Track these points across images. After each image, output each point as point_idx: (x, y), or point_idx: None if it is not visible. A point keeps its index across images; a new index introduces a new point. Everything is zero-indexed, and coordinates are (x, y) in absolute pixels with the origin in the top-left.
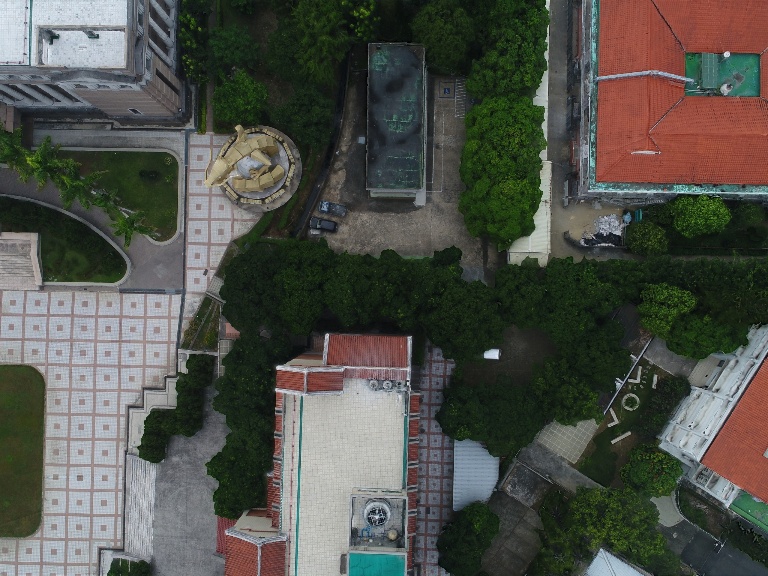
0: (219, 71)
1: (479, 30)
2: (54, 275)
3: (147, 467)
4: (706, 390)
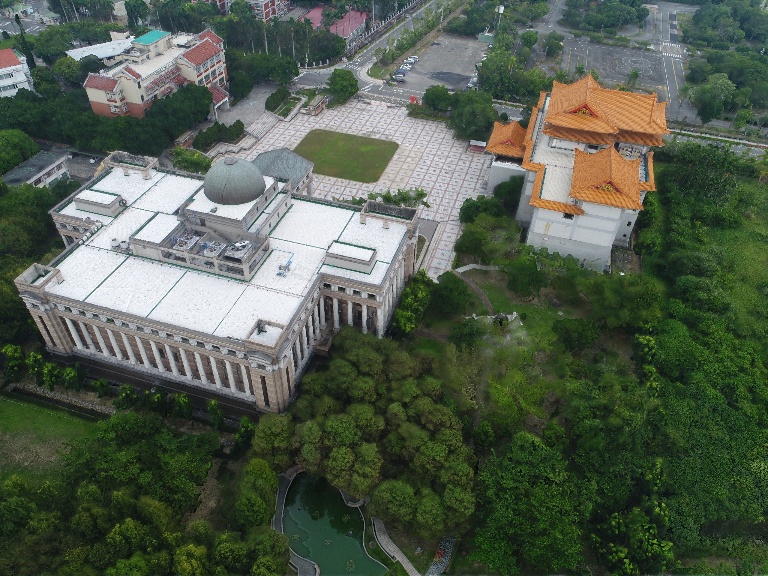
0: None
1: None
2: None
3: None
4: (0, 95)
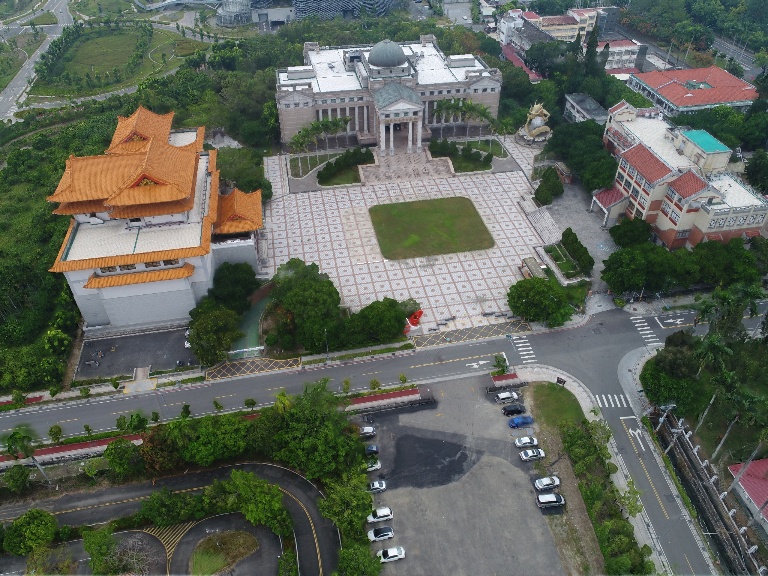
0: None
1: None
2: (459, 170)
3: (542, 214)
4: None
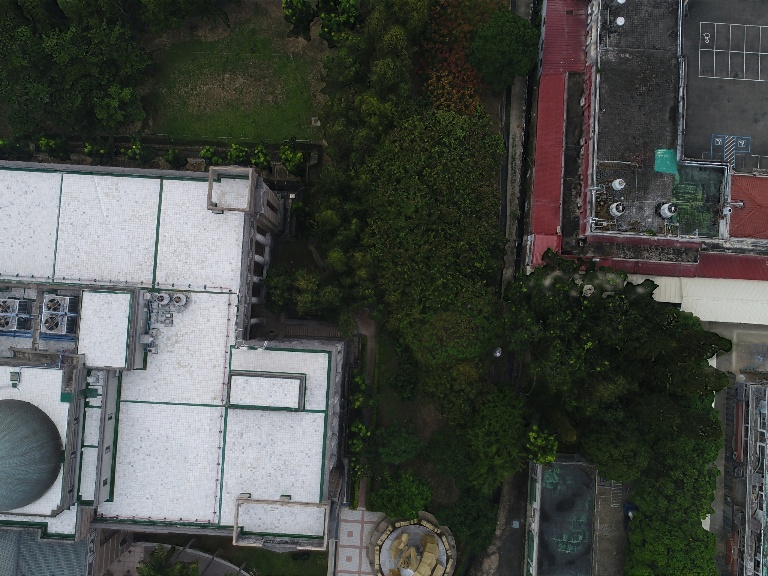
0: (383, 470)
1: (649, 445)
2: None
3: None
4: None
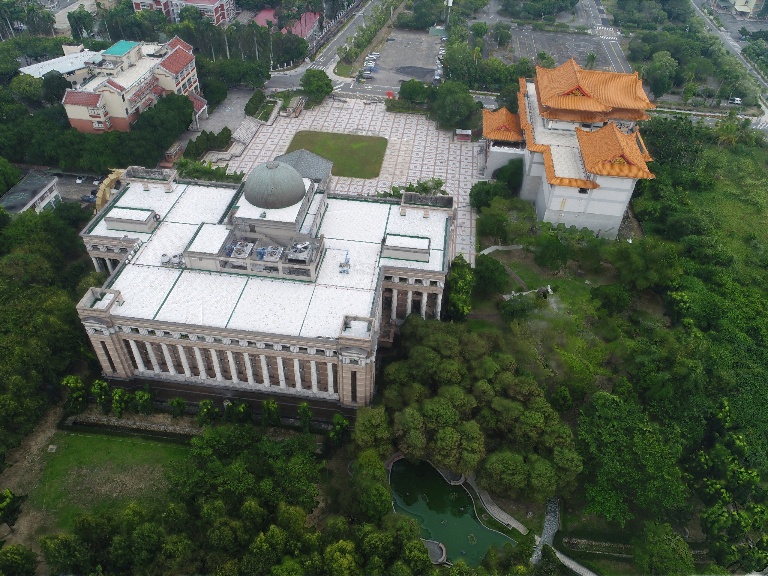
0: None
1: None
2: None
3: None
4: None
